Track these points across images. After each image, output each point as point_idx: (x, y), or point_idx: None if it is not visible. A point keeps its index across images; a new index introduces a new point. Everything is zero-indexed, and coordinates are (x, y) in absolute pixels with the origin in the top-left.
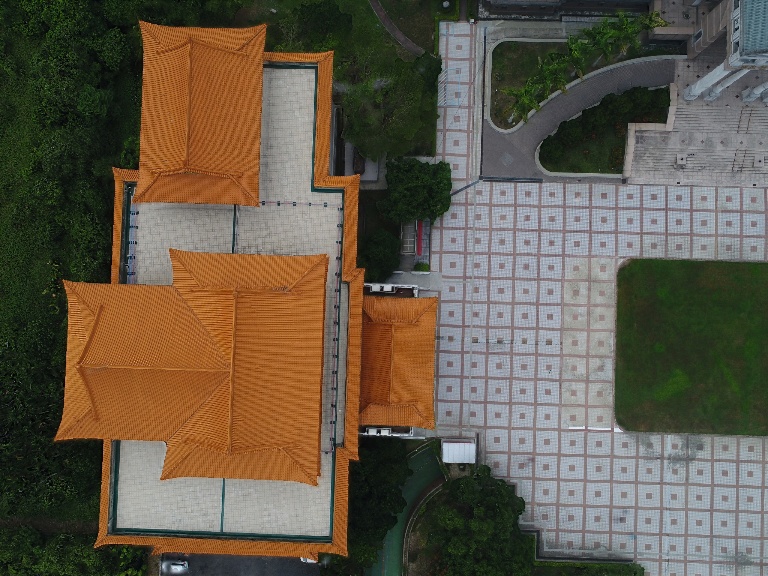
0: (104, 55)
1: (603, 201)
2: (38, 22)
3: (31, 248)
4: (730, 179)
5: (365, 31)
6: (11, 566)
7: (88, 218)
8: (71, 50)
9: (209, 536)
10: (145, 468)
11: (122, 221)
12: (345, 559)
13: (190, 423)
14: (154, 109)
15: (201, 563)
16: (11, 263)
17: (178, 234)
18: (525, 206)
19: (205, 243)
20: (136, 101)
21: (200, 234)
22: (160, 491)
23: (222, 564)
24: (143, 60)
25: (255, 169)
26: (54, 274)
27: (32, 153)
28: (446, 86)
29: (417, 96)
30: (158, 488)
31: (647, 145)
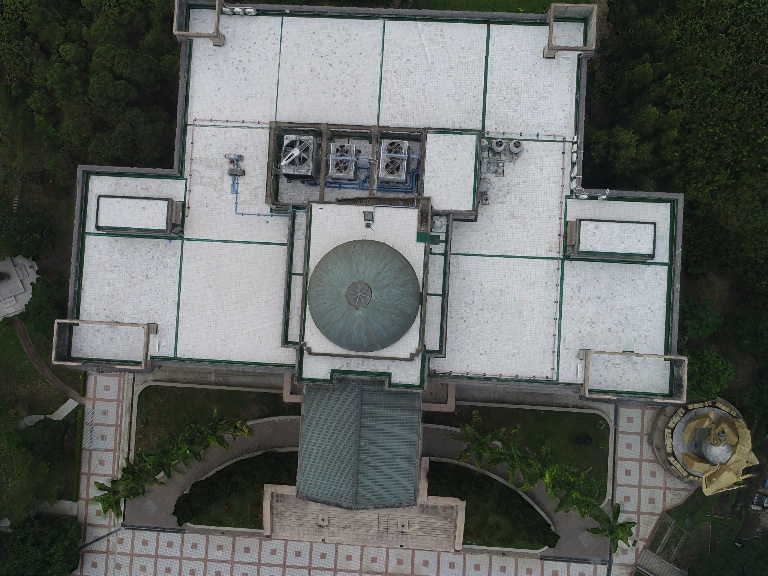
0: None
1: (245, 556)
2: None
3: None
4: (376, 539)
5: None
6: None
7: None
8: None
9: None
10: None
11: None
12: None
13: None
14: None
15: None
16: None
17: None
18: (166, 557)
19: None
20: None
21: None
22: None
23: None
24: None
25: None
26: None
27: None
28: (92, 428)
29: (23, 473)
30: None
31: (287, 504)
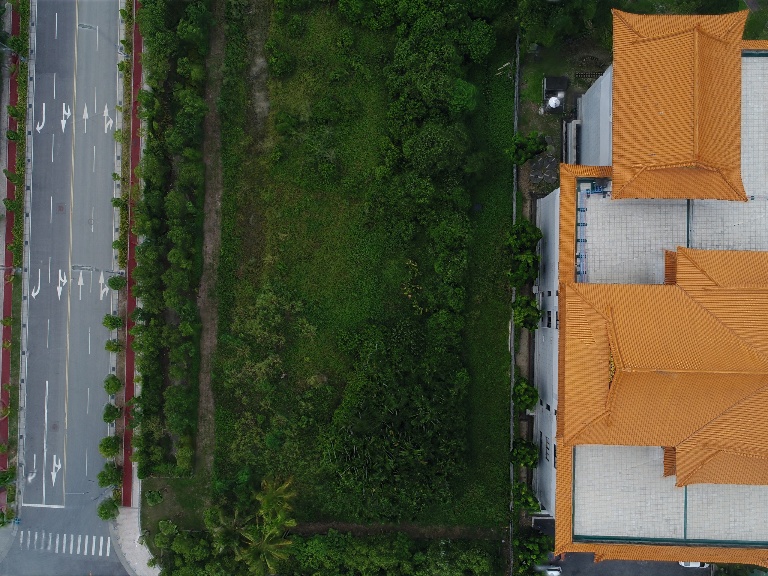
0: (470, 47)
1: None
2: (390, 15)
3: (383, 248)
4: None
5: (762, 17)
6: (390, 573)
7: (460, 216)
8: (444, 43)
9: (675, 543)
10: (603, 473)
11: (575, 218)
12: (744, 564)
13: (710, 428)
14: (631, 101)
15: (573, 568)
16: (363, 263)
17: (629, 231)
18: None
19: (658, 240)
20: (488, 95)
21: (652, 231)
22: (619, 497)
23: (595, 569)
24: (613, 50)
25: (737, 162)
26: (415, 274)
27: (390, 150)
28: None
29: None
30: (617, 494)
31: None
